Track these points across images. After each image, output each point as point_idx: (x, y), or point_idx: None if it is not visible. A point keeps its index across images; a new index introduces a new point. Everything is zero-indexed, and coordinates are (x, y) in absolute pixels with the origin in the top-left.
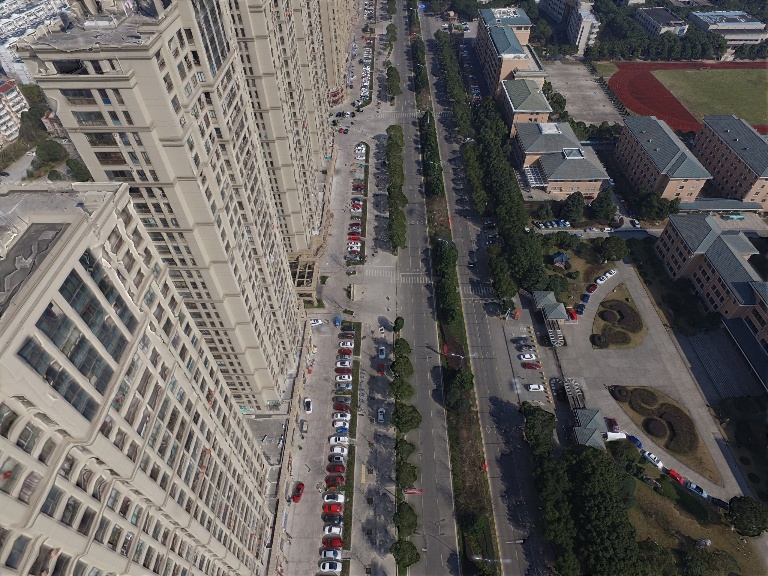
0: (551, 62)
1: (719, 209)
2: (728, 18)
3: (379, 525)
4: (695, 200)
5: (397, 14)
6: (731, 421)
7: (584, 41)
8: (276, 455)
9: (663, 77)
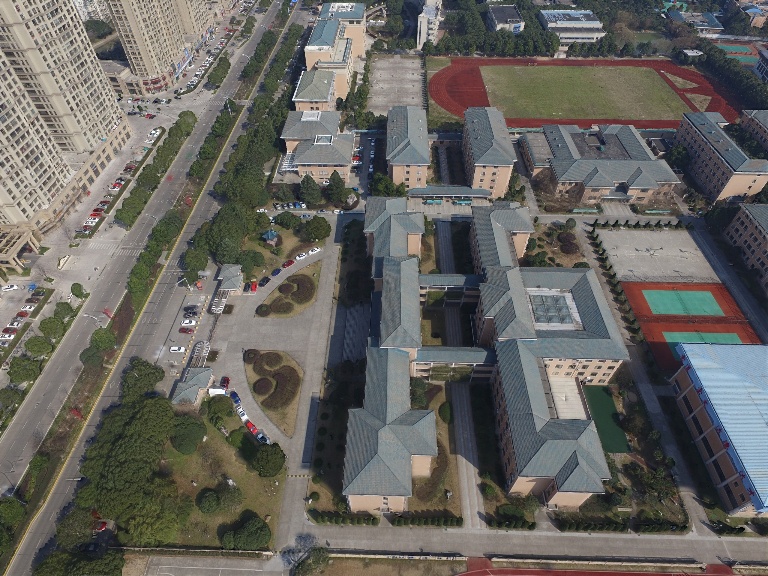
0: (390, 56)
1: (449, 195)
2: (571, 17)
3: None
4: (428, 186)
5: (274, 7)
6: (335, 382)
7: (425, 36)
8: None
9: (488, 72)
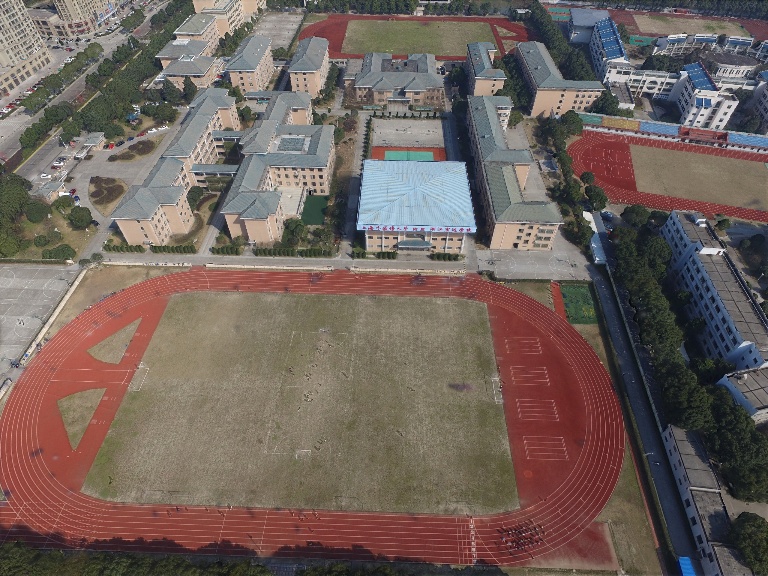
0: (280, 13)
1: None
2: None
3: None
4: None
5: None
6: None
7: None
8: None
9: (353, 24)
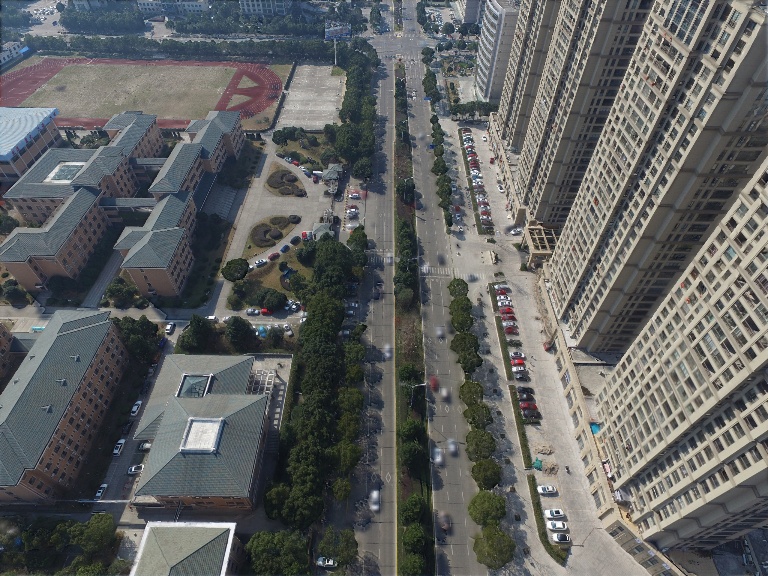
0: None
1: None
2: None
3: (449, 155)
4: None
5: None
6: None
7: None
8: (508, 153)
9: None
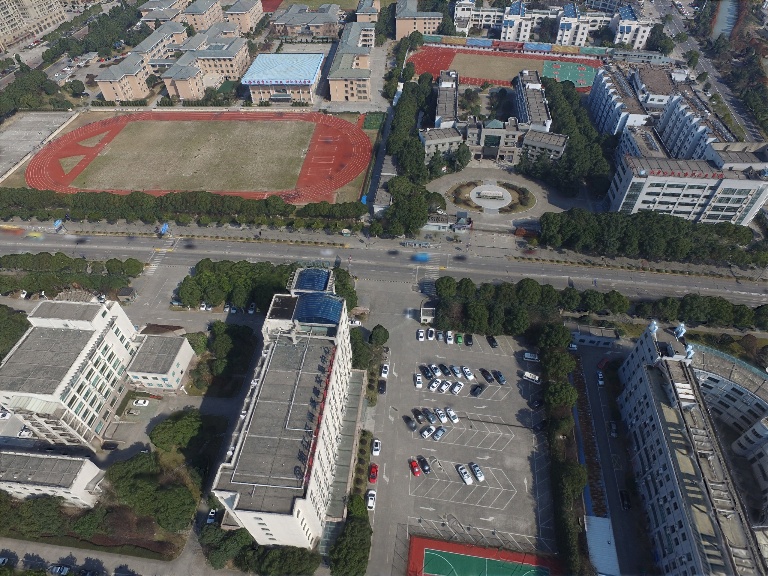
0: None
1: None
2: None
3: None
4: None
5: None
6: None
7: None
8: None
9: None
